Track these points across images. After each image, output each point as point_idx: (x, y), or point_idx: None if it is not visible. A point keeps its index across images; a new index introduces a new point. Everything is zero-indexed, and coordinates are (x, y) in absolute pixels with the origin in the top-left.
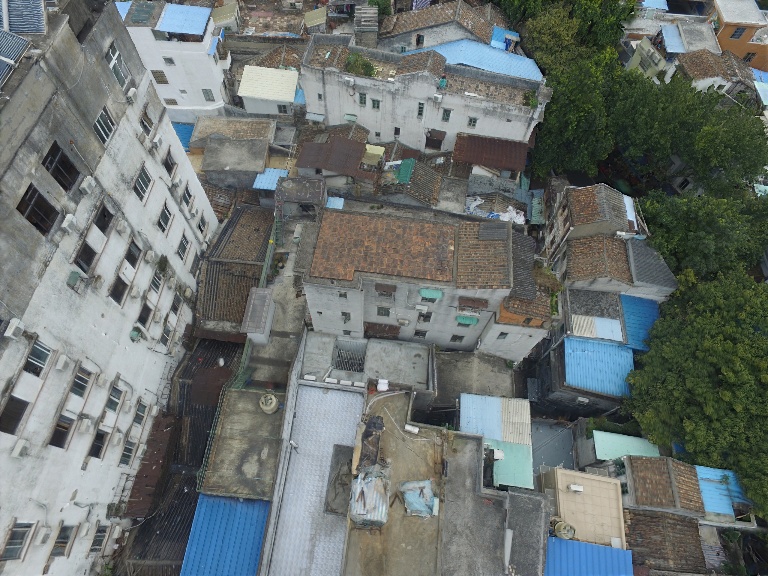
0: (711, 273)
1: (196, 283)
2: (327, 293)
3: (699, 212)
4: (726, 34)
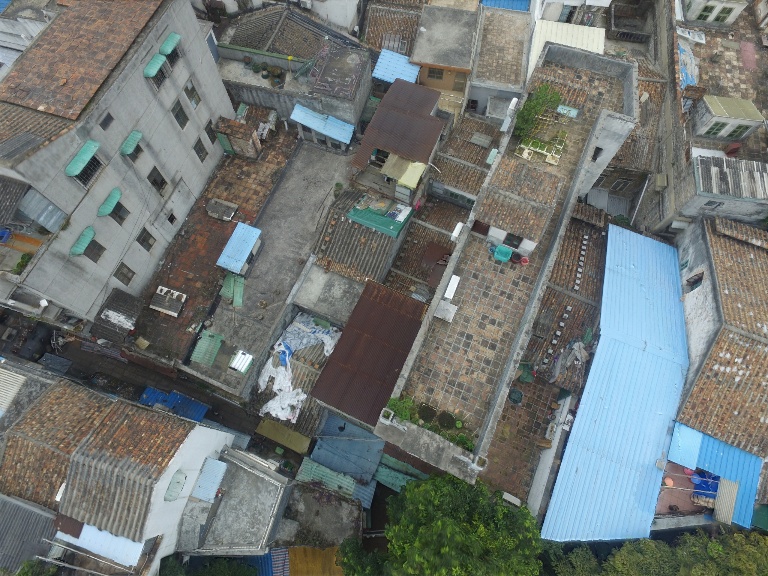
0: None
1: (263, 3)
2: None
3: None
4: None
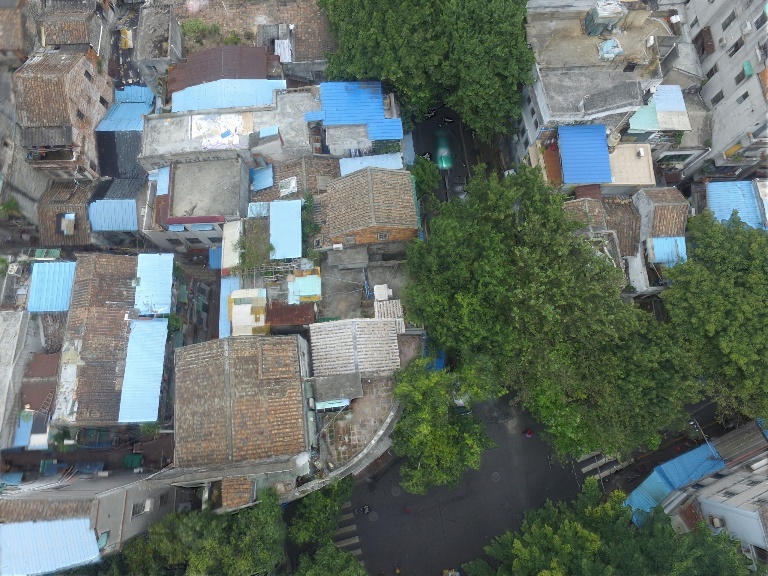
0: None
1: None
2: None
3: None
4: None
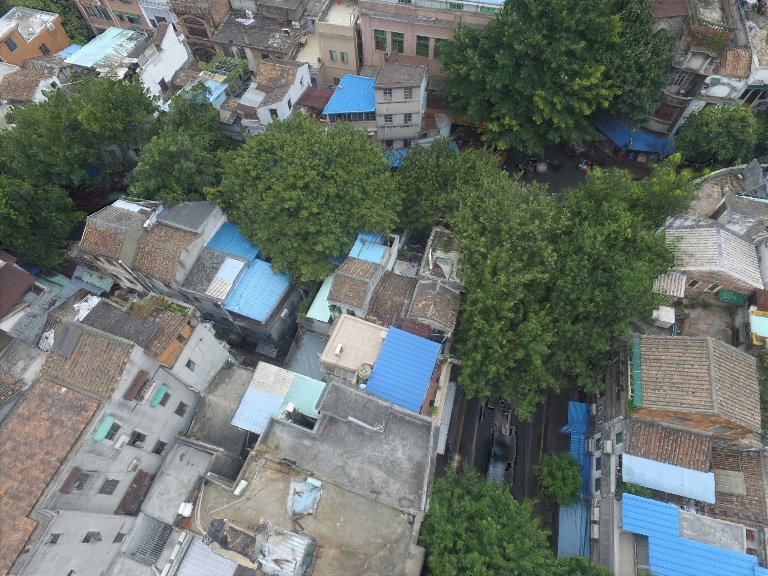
0: (218, 174)
1: None
2: (41, 560)
3: (155, 159)
4: (5, 53)
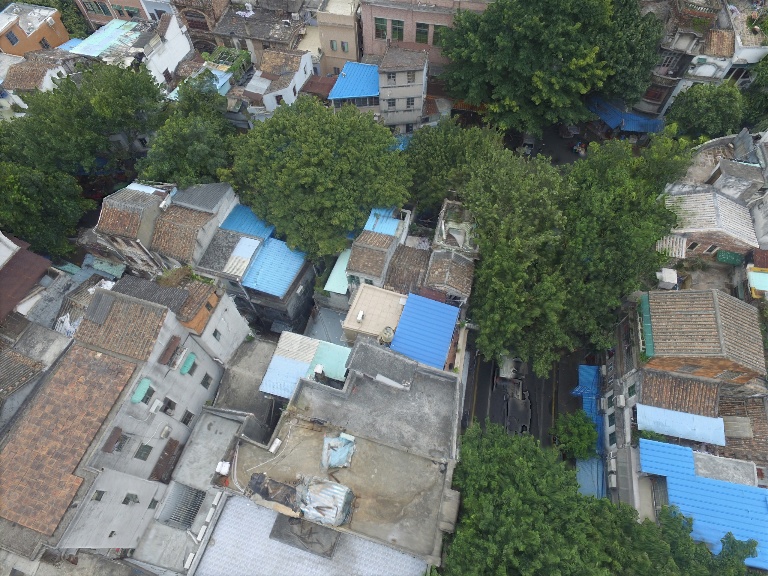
0: (228, 158)
1: None
2: (87, 517)
3: (170, 141)
4: (6, 46)
